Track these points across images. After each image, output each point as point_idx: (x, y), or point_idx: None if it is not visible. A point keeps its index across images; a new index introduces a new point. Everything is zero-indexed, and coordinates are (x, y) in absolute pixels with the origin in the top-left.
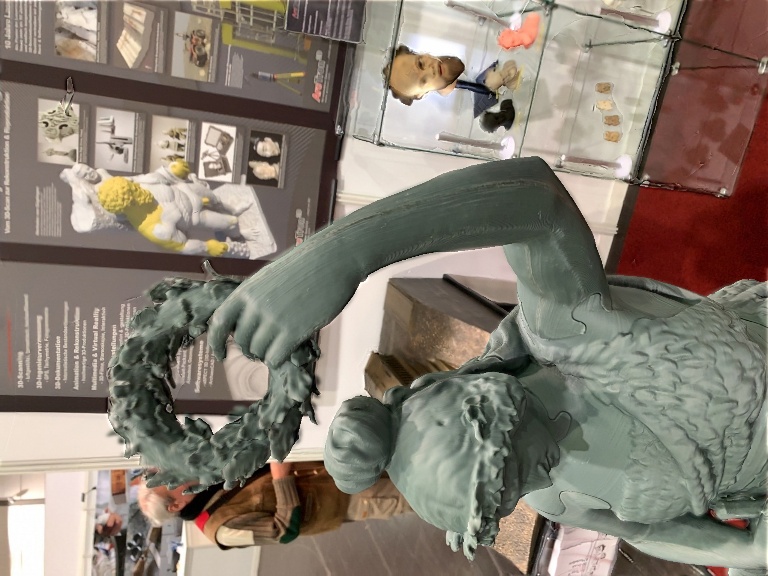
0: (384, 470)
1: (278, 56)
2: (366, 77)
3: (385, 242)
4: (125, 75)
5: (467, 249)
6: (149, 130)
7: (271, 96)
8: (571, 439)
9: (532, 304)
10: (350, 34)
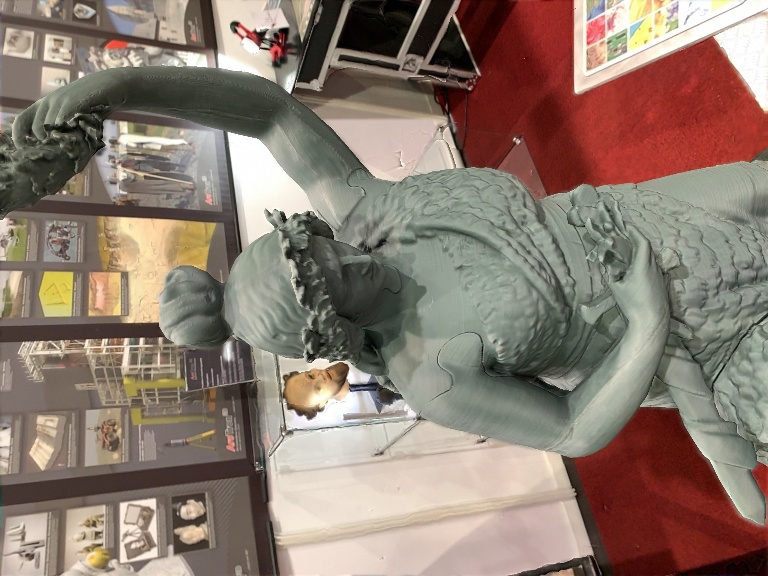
0: (223, 321)
1: (187, 422)
2: (273, 419)
3: (142, 68)
4: (37, 479)
5: (224, 114)
6: (63, 526)
7: (187, 459)
8: (411, 294)
9: (319, 195)
10: (244, 376)
